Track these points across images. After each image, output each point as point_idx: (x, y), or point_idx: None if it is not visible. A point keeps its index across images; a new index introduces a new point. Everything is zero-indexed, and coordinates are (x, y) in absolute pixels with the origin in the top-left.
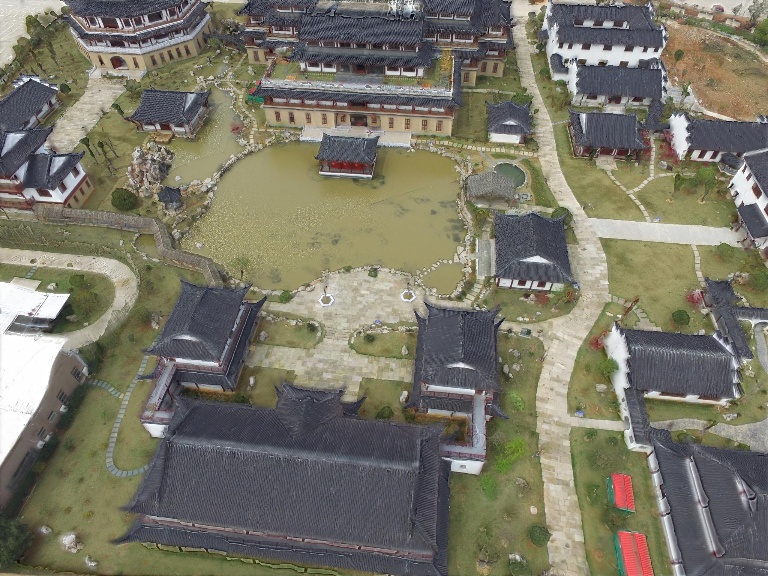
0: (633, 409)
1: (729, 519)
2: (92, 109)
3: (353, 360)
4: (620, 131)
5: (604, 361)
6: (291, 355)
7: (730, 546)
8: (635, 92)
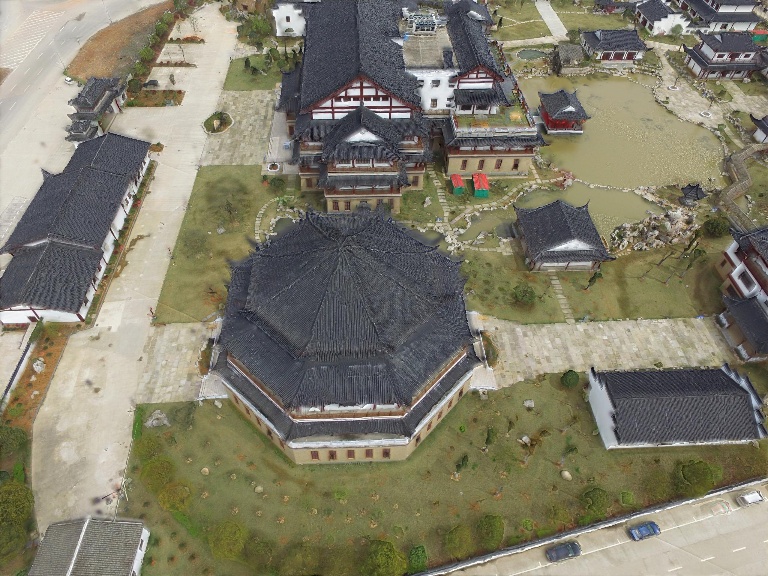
0: (695, 26)
1: (746, 1)
2: (578, 342)
3: (739, 99)
4: (477, 8)
5: (677, 29)
6: (759, 118)
7: (754, 3)
8: (413, 2)
